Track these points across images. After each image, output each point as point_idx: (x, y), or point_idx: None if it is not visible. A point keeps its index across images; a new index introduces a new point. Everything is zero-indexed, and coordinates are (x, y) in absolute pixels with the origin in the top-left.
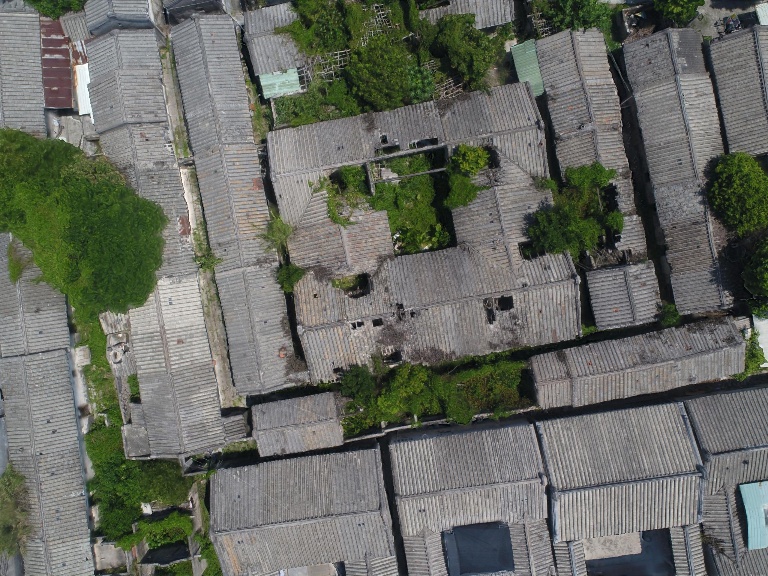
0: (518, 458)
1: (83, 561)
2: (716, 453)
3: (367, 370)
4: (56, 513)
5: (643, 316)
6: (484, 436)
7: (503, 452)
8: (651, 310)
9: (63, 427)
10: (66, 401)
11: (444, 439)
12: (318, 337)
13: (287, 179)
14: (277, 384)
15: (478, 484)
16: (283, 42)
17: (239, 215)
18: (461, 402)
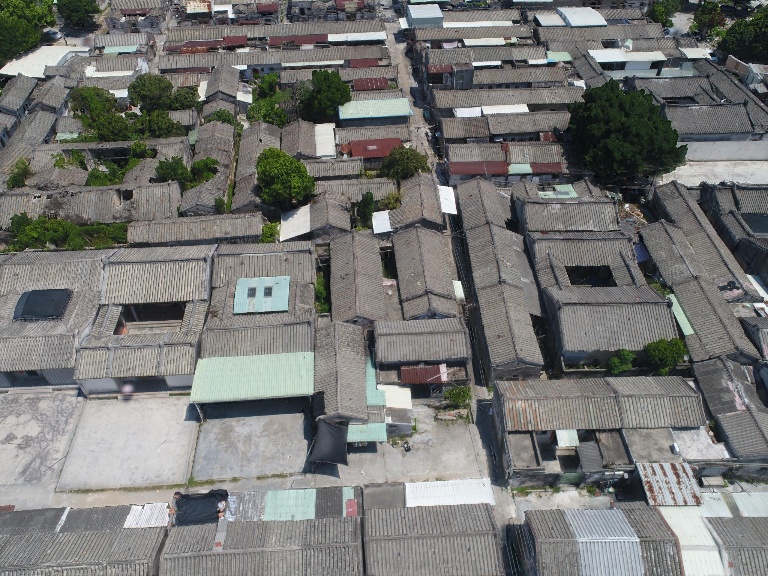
0: None
1: None
2: None
3: (31, 219)
4: None
5: None
6: (84, 251)
7: None
8: (212, 203)
9: None
10: None
11: None
12: (11, 200)
13: (41, 152)
14: None
15: None
16: (76, 122)
17: (7, 165)
18: None
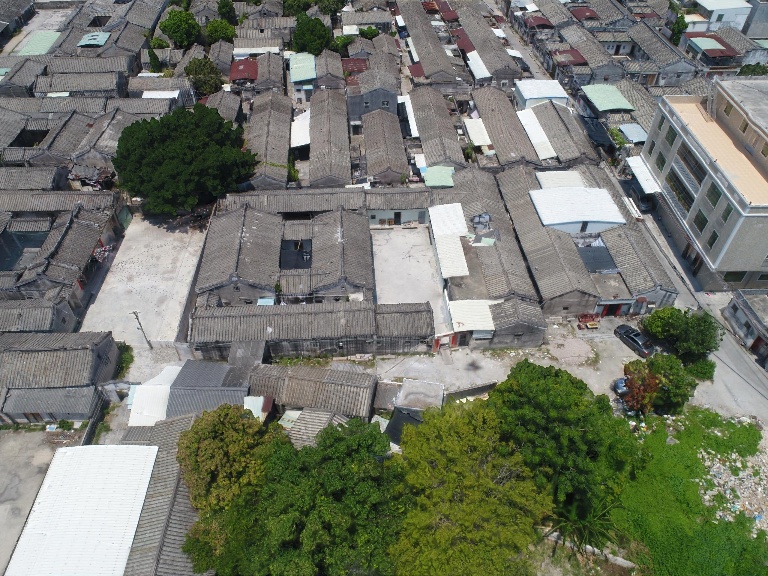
0: (151, 1)
1: None
2: (127, 24)
3: None
4: None
5: None
6: None
7: (155, 1)
8: None
9: None
10: None
11: None
12: None
13: None
14: None
15: None
16: None
17: None
18: (177, 0)
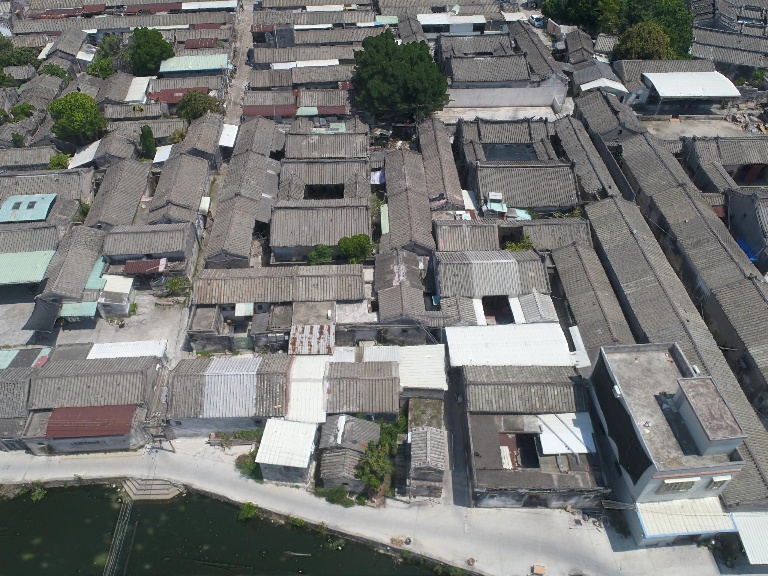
0: None
1: None
2: None
3: None
4: None
5: None
6: None
7: None
8: (12, 138)
9: None
10: None
11: None
12: None
13: None
14: None
15: None
16: None
17: None
18: None
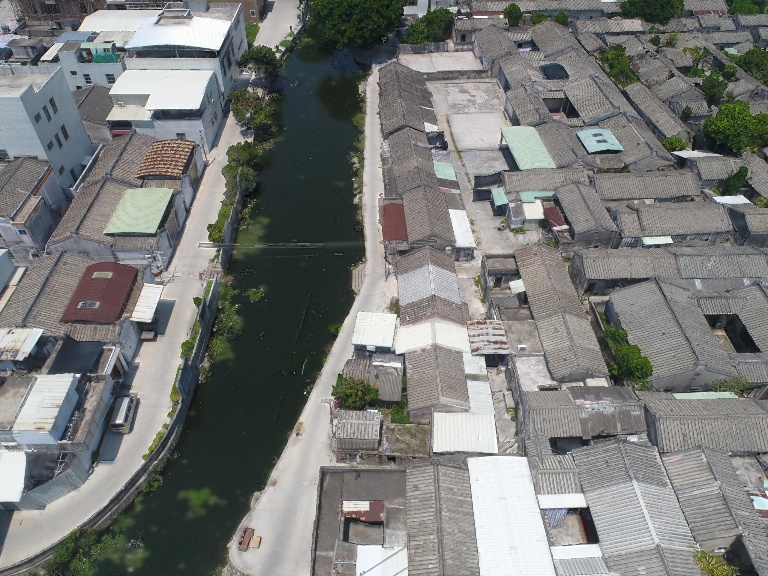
0: None
1: (527, 8)
2: None
3: None
4: (545, 4)
5: (683, 106)
6: None
7: None
8: None
9: (576, 7)
10: (585, 8)
11: (600, 68)
12: (635, 41)
13: None
14: (608, 40)
15: (588, 65)
16: None
17: None
18: None
